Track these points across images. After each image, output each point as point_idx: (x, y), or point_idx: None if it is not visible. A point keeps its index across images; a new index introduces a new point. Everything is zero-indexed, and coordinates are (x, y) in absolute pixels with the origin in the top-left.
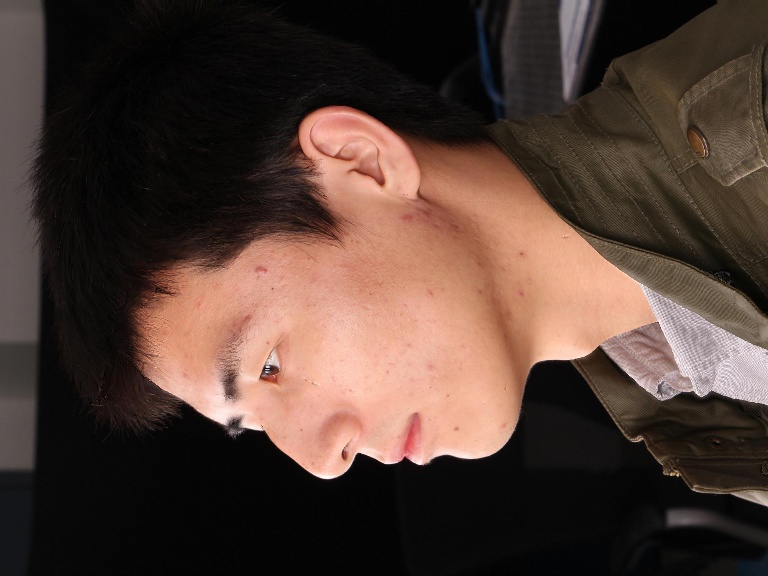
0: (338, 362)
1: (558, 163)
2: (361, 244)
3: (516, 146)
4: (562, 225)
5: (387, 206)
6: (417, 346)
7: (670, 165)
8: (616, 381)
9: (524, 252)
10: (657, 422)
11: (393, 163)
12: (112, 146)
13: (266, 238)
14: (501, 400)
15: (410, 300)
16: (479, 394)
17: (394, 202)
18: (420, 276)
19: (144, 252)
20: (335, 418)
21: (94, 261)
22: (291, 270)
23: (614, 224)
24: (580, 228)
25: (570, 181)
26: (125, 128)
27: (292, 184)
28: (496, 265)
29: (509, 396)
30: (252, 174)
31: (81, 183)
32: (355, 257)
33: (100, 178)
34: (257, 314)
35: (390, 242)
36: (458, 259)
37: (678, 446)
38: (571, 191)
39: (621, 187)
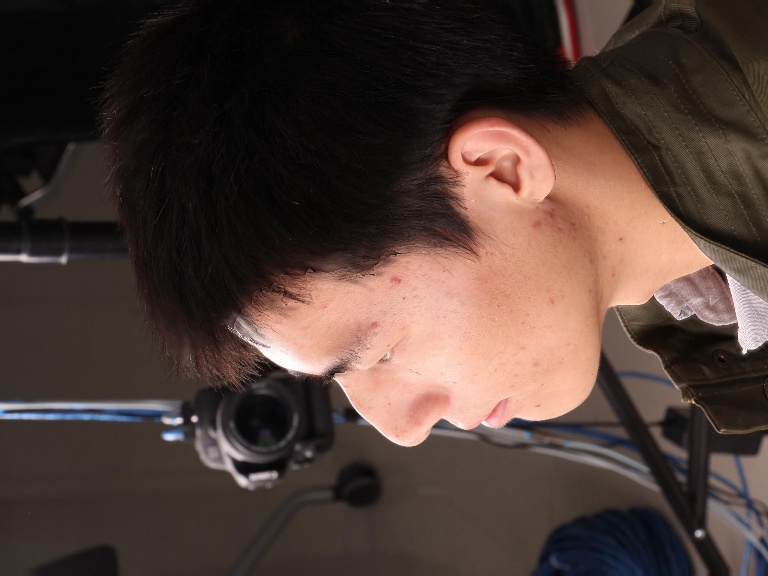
0: (454, 365)
1: (660, 142)
2: (495, 256)
3: (614, 113)
4: (663, 212)
5: (520, 214)
6: (529, 348)
7: None
8: None
9: (623, 237)
10: (661, 326)
11: (532, 172)
12: (251, 142)
13: (404, 249)
14: (587, 384)
15: (533, 310)
16: (570, 381)
17: (526, 208)
18: (545, 286)
19: None
20: (427, 397)
21: (217, 254)
22: (425, 281)
23: (714, 217)
24: (688, 227)
25: (671, 163)
26: (269, 127)
27: (434, 193)
28: (600, 255)
29: (593, 378)
30: (398, 185)
31: (205, 167)
32: (488, 269)
33: (236, 176)
34: (385, 321)
35: (521, 253)
36: (577, 262)
37: (694, 370)
38: (672, 174)
39: (725, 179)
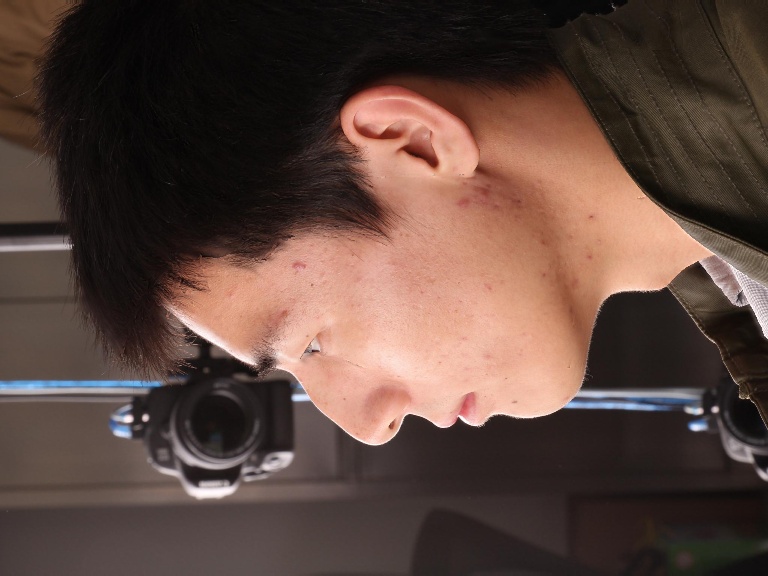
0: (385, 357)
1: (635, 107)
2: (411, 238)
3: (588, 76)
4: None
5: (441, 191)
6: (473, 339)
7: (763, 135)
8: (691, 275)
9: (594, 215)
10: (735, 313)
11: (448, 145)
12: (128, 119)
13: (304, 231)
14: (564, 378)
15: (466, 296)
16: (540, 375)
17: (449, 185)
18: (477, 270)
19: (168, 248)
20: (381, 392)
21: (111, 239)
22: (333, 266)
23: (697, 191)
24: (658, 202)
25: (648, 131)
26: (142, 102)
27: (333, 170)
28: (562, 235)
29: (573, 372)
30: (288, 162)
31: (93, 147)
32: (404, 252)
33: (115, 155)
34: (295, 310)
35: (444, 234)
36: (520, 244)
37: (757, 362)
38: (649, 143)
39: (706, 148)
